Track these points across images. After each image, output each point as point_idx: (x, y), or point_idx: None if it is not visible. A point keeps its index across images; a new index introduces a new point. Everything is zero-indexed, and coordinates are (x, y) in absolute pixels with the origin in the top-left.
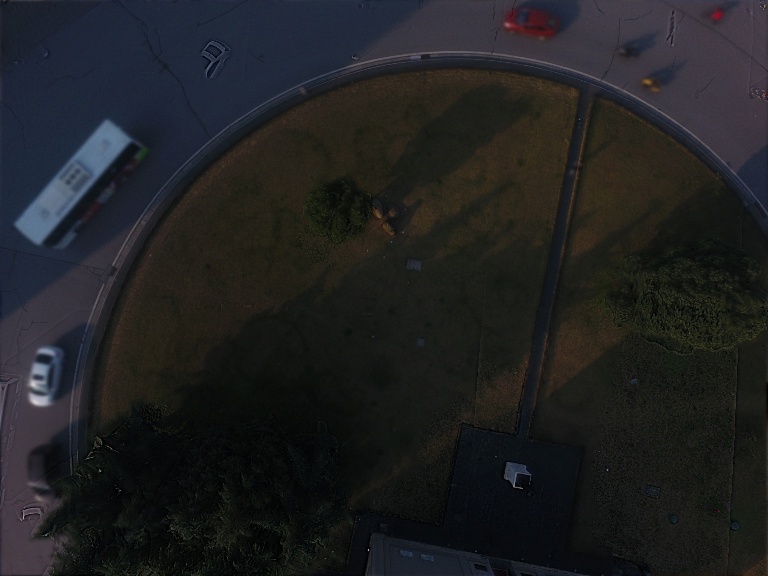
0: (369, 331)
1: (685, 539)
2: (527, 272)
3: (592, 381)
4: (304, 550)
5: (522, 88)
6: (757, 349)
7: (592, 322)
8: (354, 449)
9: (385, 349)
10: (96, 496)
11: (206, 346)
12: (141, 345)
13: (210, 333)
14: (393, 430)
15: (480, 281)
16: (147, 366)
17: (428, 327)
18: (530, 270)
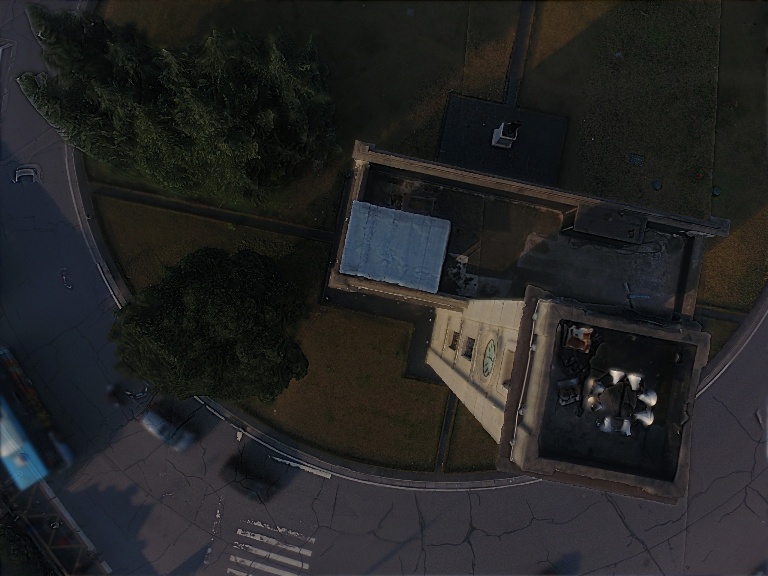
0: (360, 0)
1: (668, 205)
2: None
3: (578, 53)
4: (293, 75)
5: None
6: (738, 26)
7: None
8: (344, 113)
9: (375, 18)
10: (89, 42)
11: (199, 12)
12: (135, 12)
13: (203, 0)
14: (383, 96)
15: None
16: (141, 32)
17: None
18: None
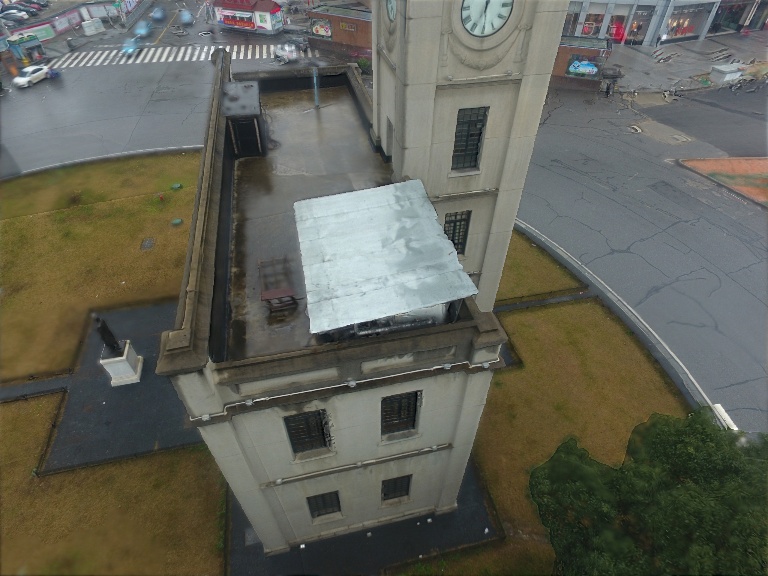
0: None
1: None
2: None
3: None
4: None
5: None
6: None
7: None
8: None
9: None
10: None
11: None
12: None
13: None
14: None
15: None
16: None
17: None
18: None
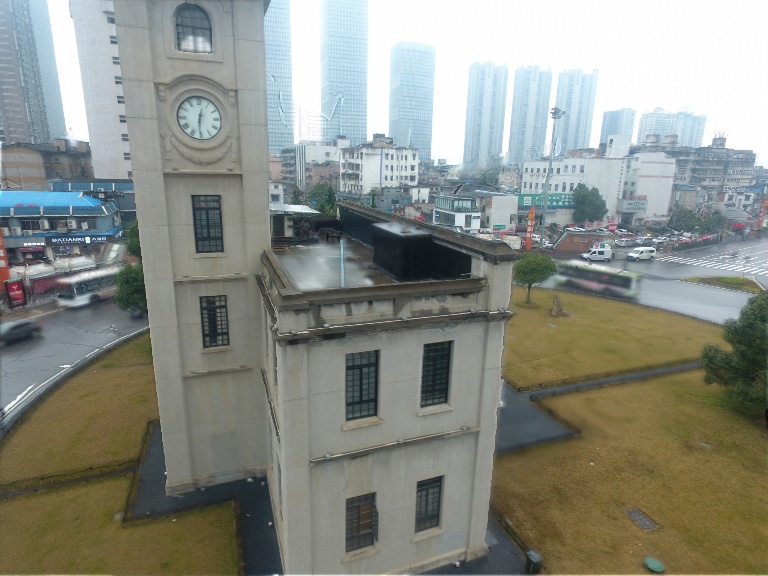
0: None
1: None
2: (640, 359)
3: (645, 416)
4: None
5: (722, 330)
6: None
7: (684, 398)
8: None
9: None
10: None
11: None
12: None
13: None
14: None
15: (592, 344)
16: None
17: (526, 336)
18: (644, 360)
